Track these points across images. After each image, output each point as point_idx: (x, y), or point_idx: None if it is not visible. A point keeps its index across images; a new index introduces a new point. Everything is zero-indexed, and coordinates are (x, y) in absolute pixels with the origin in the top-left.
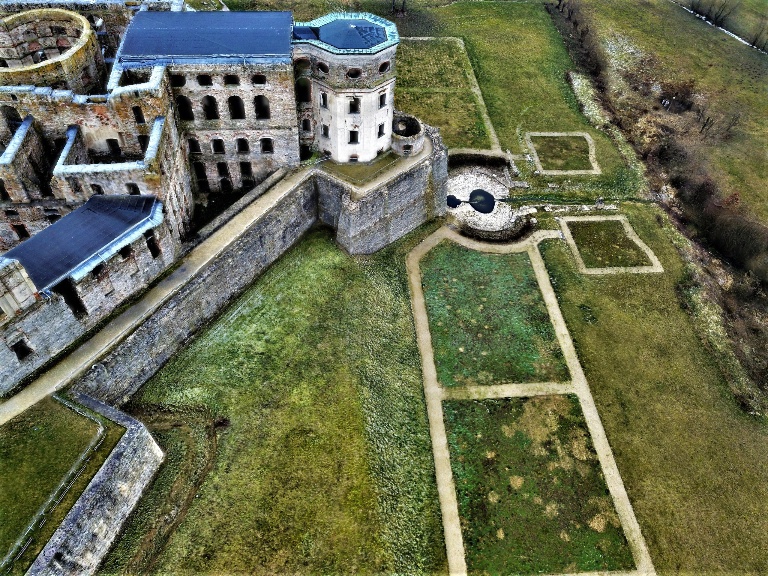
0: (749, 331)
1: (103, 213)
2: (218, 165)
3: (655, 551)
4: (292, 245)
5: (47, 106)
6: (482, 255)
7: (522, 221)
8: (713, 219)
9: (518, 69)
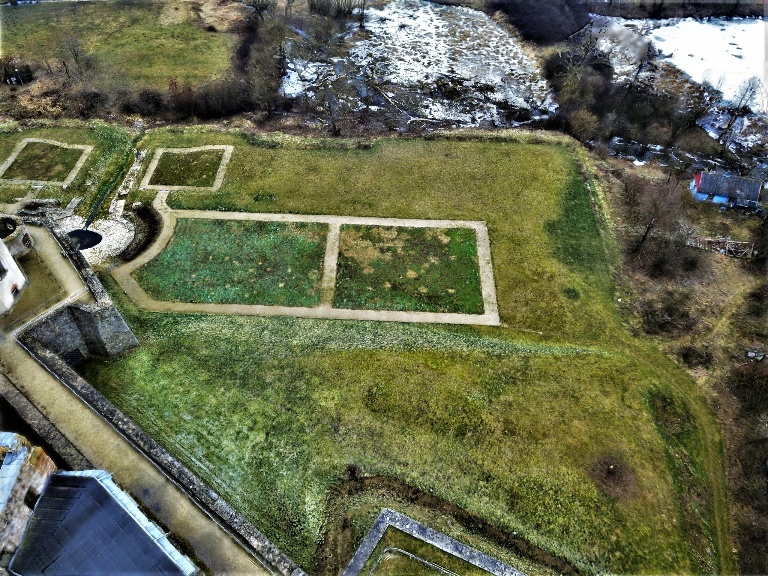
0: (297, 130)
1: (64, 545)
2: None
3: (464, 217)
4: None
5: None
6: (168, 250)
7: (129, 215)
8: (189, 103)
9: None
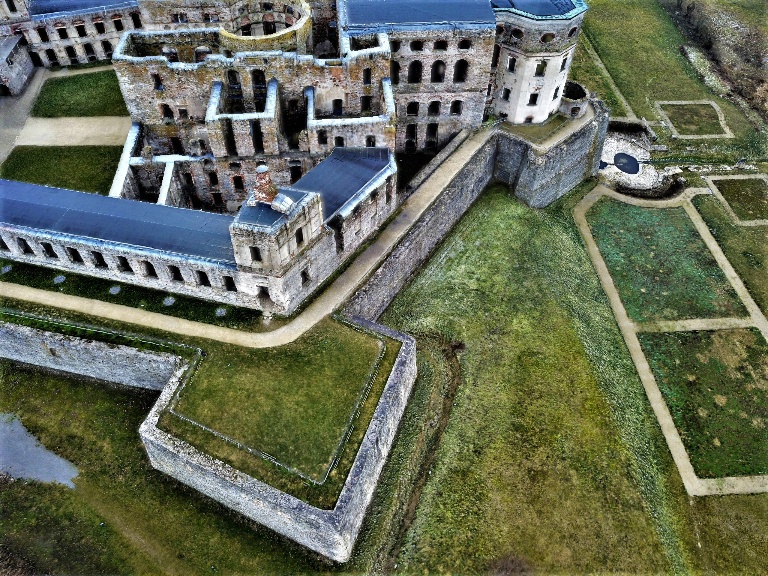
0: None
1: (349, 162)
2: (407, 127)
3: None
4: (476, 199)
5: (291, 69)
6: (641, 210)
7: (669, 180)
8: None
9: (634, 44)
